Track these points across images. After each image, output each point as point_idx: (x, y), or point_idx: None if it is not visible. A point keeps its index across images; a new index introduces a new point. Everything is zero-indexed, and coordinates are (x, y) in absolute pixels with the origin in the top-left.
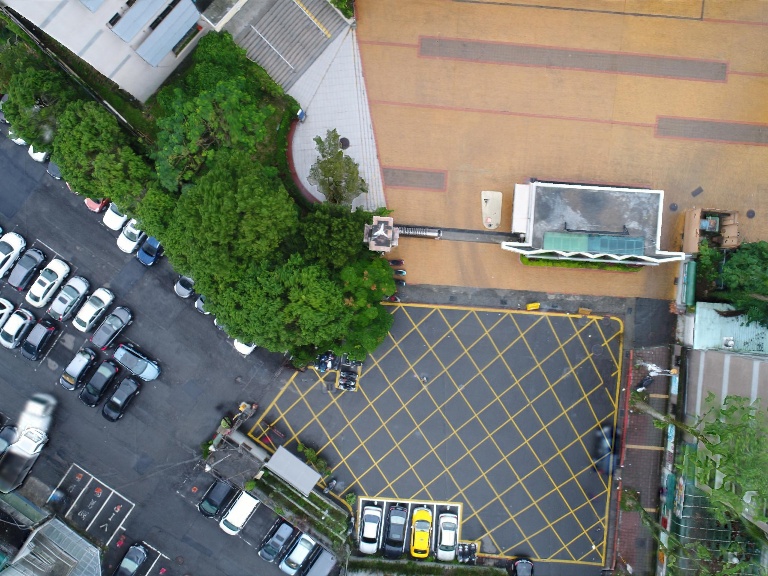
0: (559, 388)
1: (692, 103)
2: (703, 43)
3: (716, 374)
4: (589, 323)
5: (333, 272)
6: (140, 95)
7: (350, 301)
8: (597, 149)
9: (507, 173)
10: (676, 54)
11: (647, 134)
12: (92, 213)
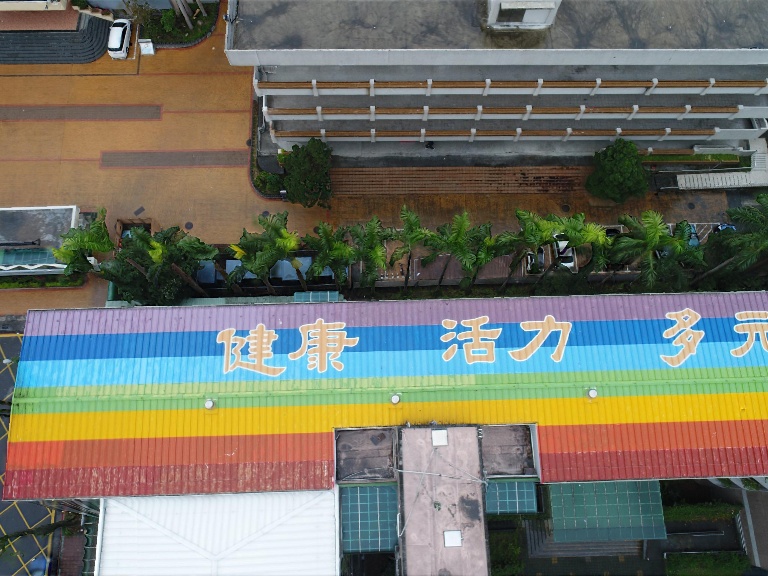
0: None
1: (132, 139)
2: (140, 92)
3: None
4: None
5: None
6: None
7: None
8: (47, 183)
9: None
10: (117, 102)
11: (92, 167)
12: None
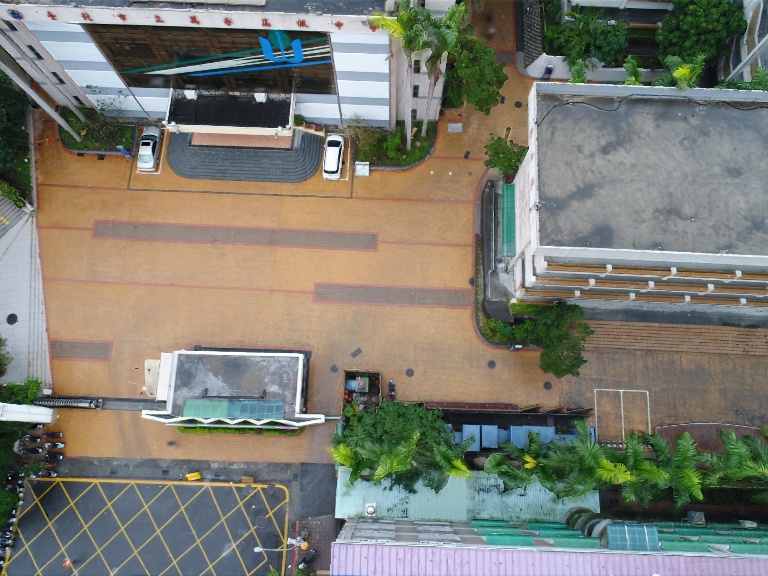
0: (219, 567)
1: (347, 270)
2: (354, 218)
3: None
4: (253, 492)
5: None
6: None
7: None
8: (259, 316)
9: (171, 341)
10: (330, 228)
11: (306, 300)
12: None
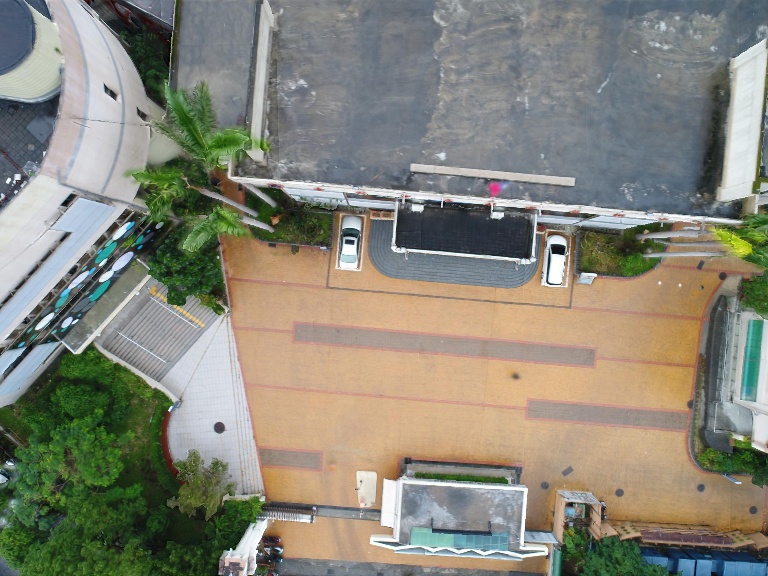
0: None
1: (562, 387)
2: (572, 330)
3: None
4: None
5: None
6: (7, 403)
7: None
8: (470, 430)
9: (382, 453)
10: (546, 340)
11: (518, 416)
12: None
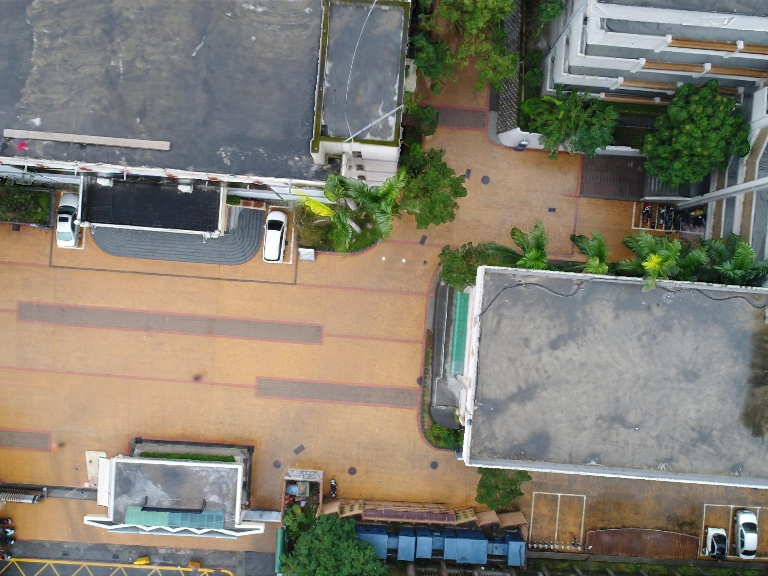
0: None
1: (290, 364)
2: (298, 307)
3: None
4: None
5: None
6: None
7: None
8: (199, 409)
9: (111, 433)
10: (272, 318)
11: (247, 394)
12: None
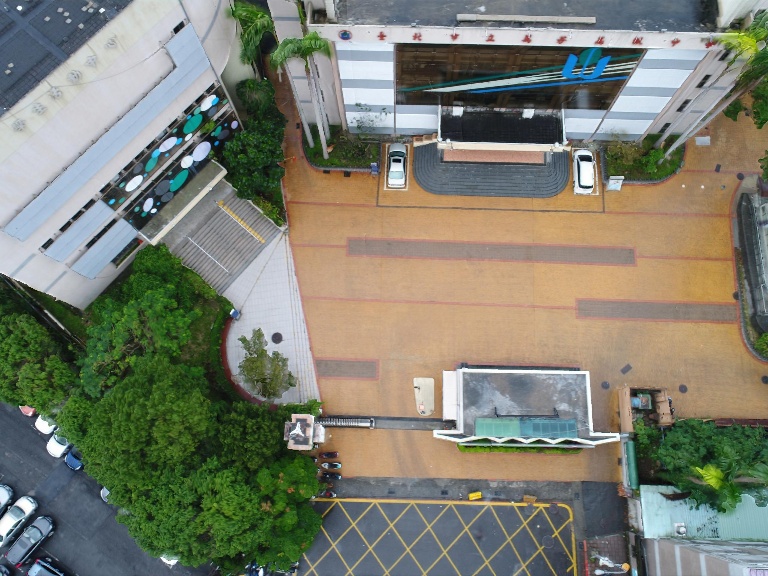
0: None
1: (607, 286)
2: (609, 232)
3: (670, 568)
4: (536, 512)
5: (251, 474)
6: (79, 304)
7: (267, 505)
8: (523, 332)
9: (437, 359)
10: (585, 243)
11: (569, 316)
12: (26, 417)
